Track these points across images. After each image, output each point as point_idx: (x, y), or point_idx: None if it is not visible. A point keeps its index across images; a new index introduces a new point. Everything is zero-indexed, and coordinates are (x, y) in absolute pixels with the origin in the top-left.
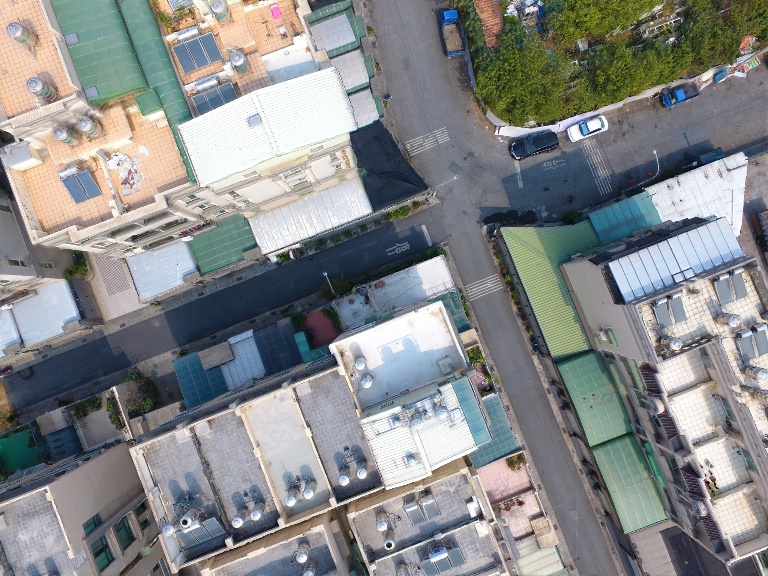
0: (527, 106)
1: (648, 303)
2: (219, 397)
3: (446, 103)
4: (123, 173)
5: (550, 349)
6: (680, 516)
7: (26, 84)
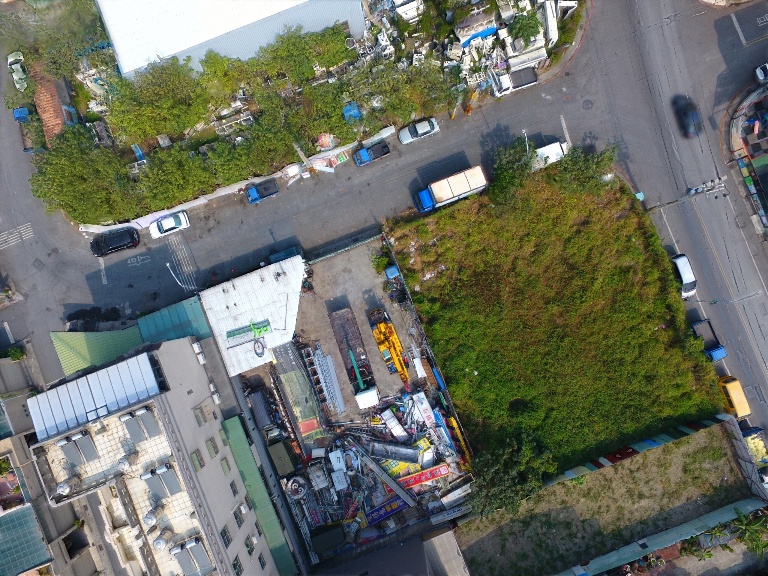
0: (76, 210)
1: (53, 443)
2: None
3: (31, 198)
4: None
5: None
6: None
7: None
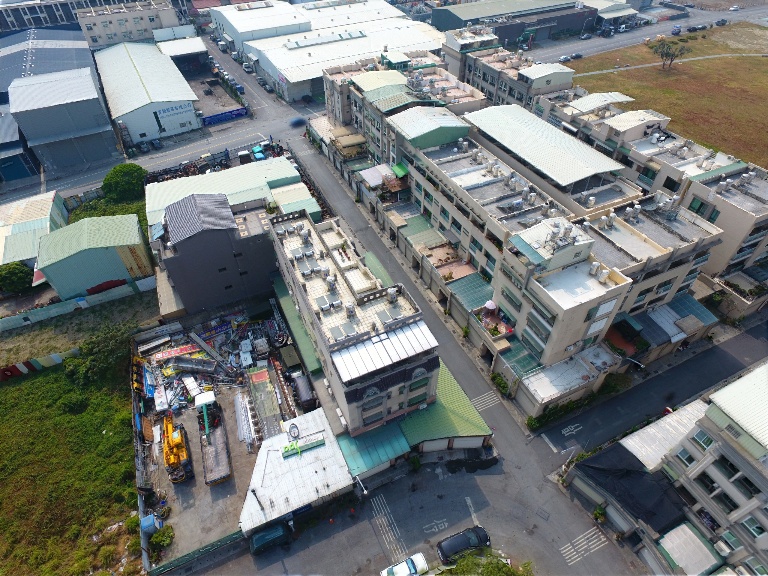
0: (496, 567)
1: None
2: None
3: None
4: None
5: None
6: None
7: None
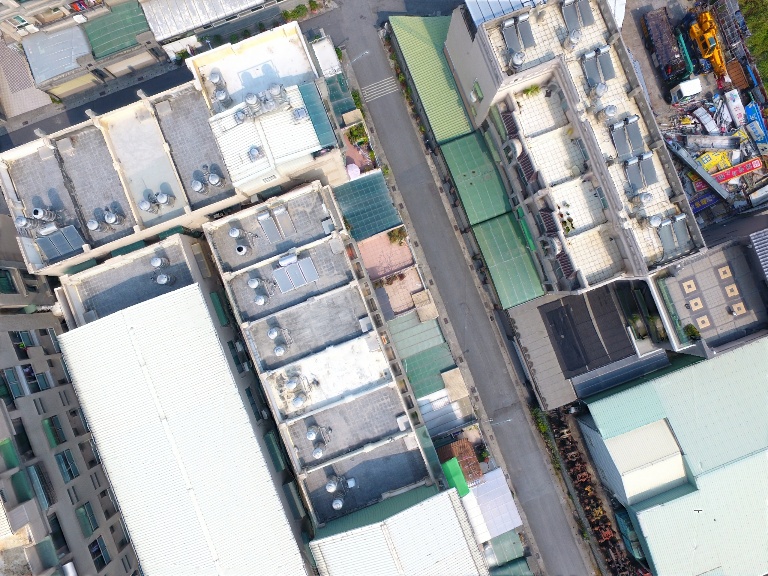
0: None
1: (497, 26)
2: None
3: None
4: None
5: (435, 134)
6: (549, 276)
7: None
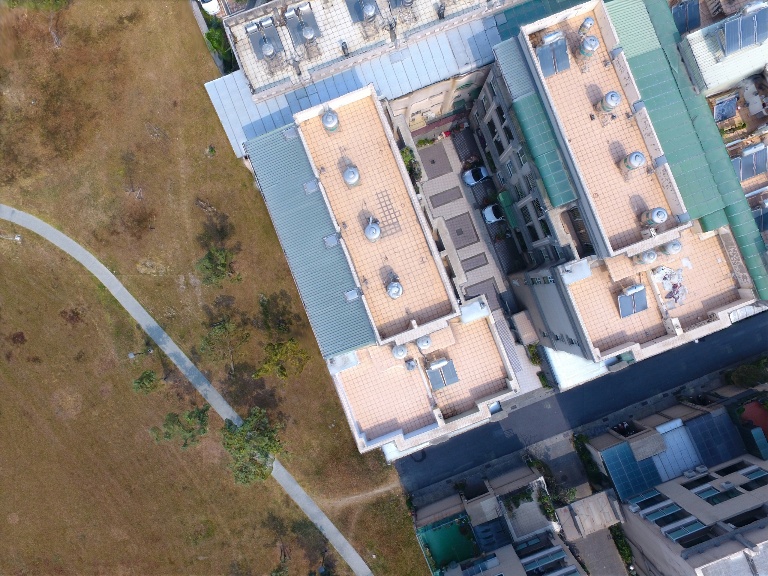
0: None
1: None
2: (681, 494)
3: None
4: (668, 287)
5: None
6: None
7: (617, 207)
